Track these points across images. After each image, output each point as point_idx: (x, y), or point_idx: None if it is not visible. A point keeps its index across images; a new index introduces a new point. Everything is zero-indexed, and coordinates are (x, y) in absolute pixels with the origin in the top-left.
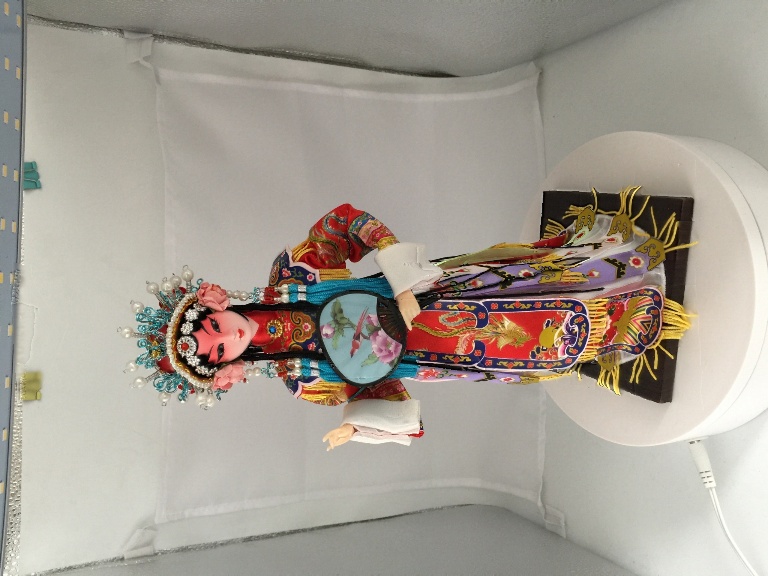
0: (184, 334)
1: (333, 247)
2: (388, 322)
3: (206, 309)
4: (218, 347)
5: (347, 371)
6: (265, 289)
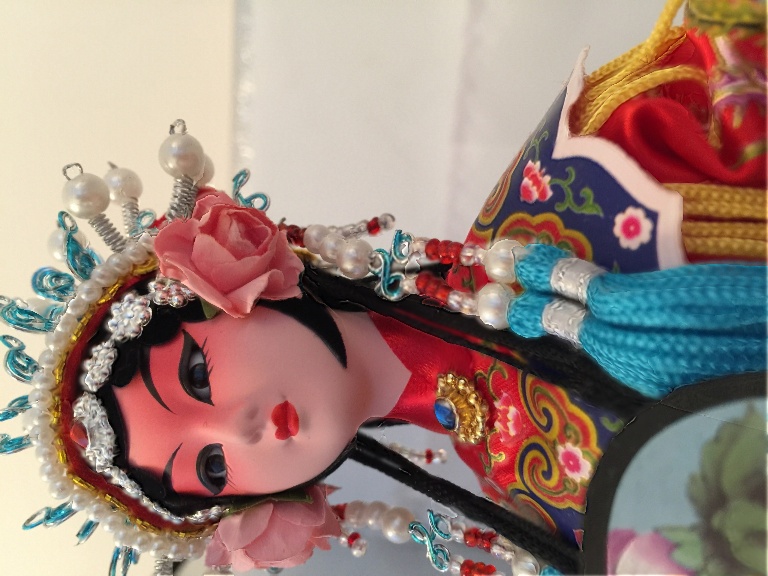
0: (88, 385)
1: None
2: None
3: (194, 298)
4: (200, 454)
5: None
6: (427, 247)
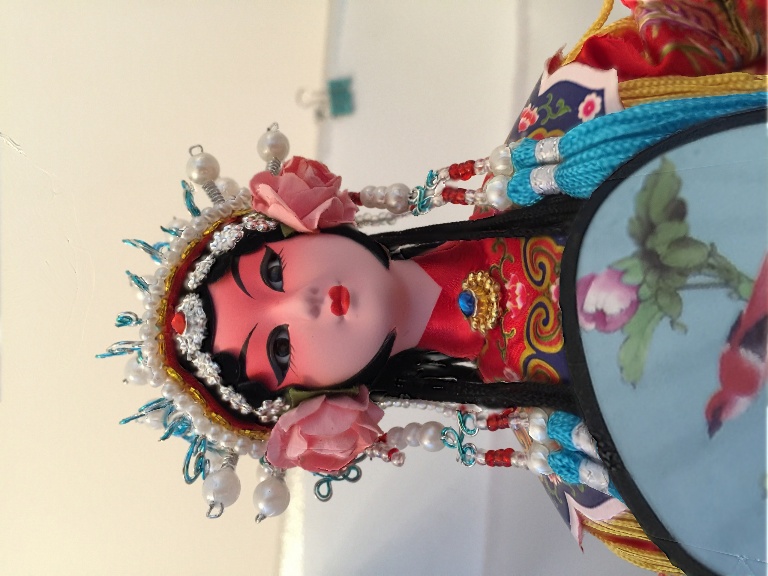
0: (190, 288)
1: None
2: None
3: (276, 227)
4: (271, 335)
5: (678, 502)
6: (450, 170)
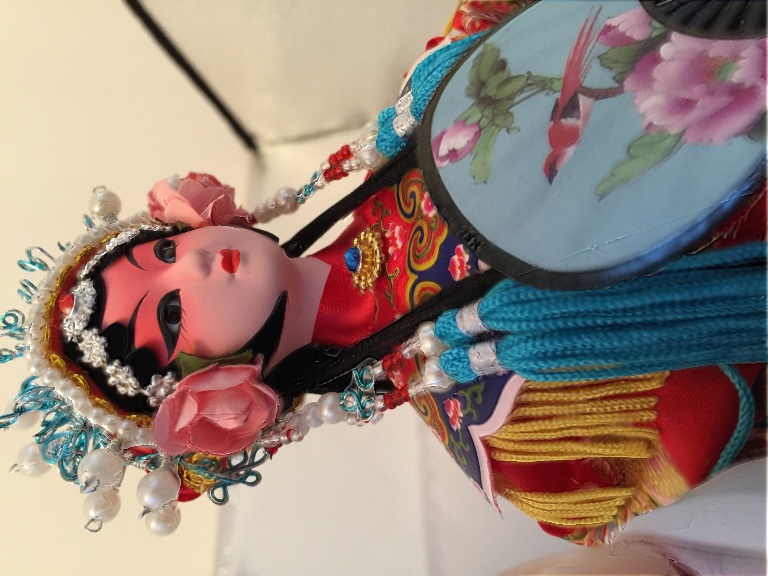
0: (82, 278)
1: (513, 8)
2: (700, 2)
3: (172, 229)
4: (162, 301)
5: (534, 238)
6: (330, 160)
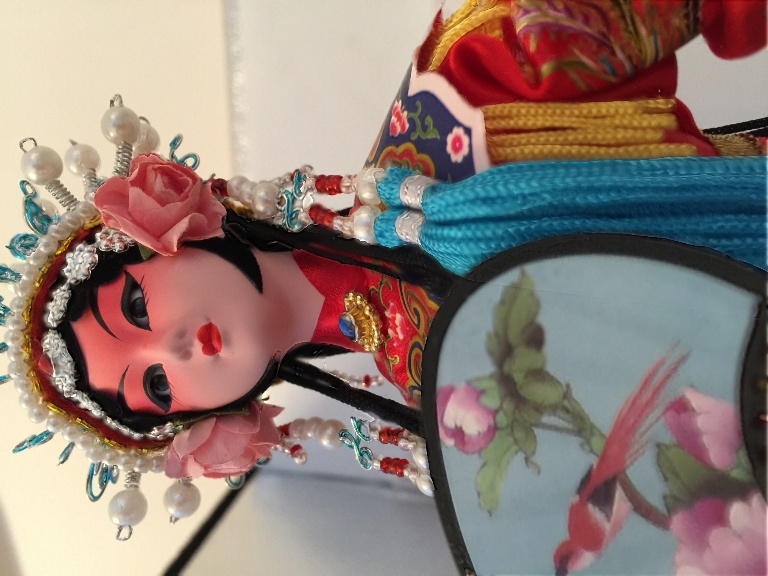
0: (51, 323)
1: None
2: None
3: (134, 244)
4: (145, 374)
5: None
6: (316, 182)
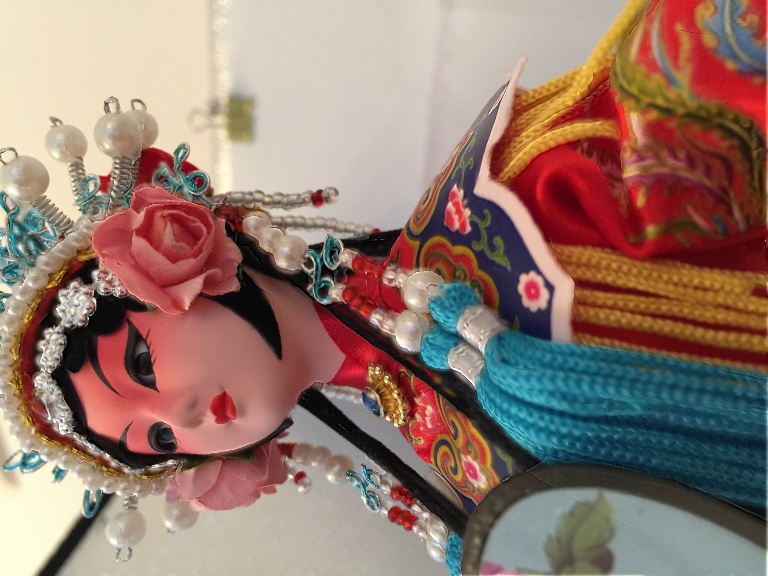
0: (43, 365)
1: (730, 142)
2: None
3: None
4: (150, 429)
5: None
6: (354, 262)
